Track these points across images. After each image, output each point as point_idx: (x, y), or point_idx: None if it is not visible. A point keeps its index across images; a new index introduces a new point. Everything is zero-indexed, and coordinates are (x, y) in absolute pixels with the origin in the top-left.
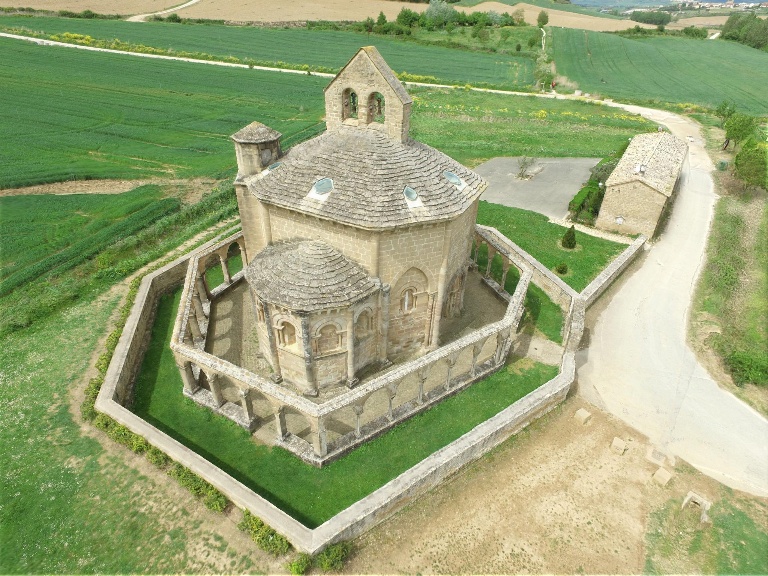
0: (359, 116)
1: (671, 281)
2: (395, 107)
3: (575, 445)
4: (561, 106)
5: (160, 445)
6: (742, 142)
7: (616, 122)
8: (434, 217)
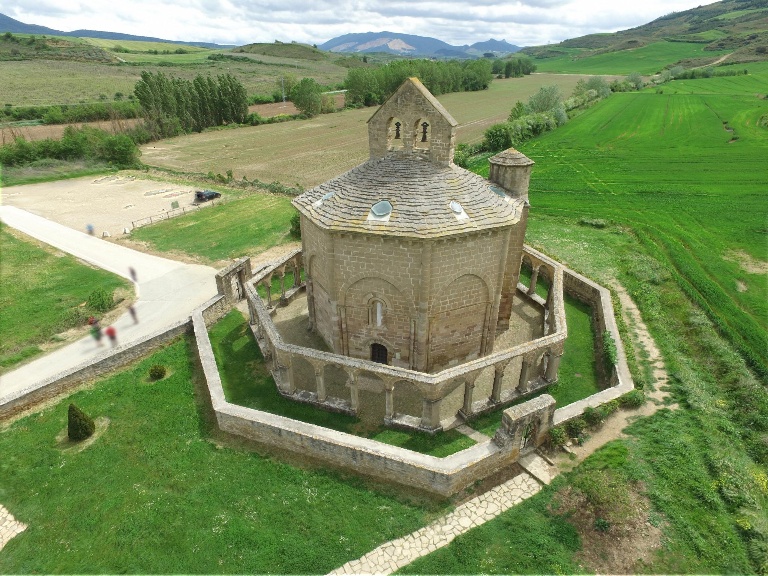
0: None
1: (3, 389)
2: None
3: None
4: None
5: None
6: None
7: None
8: None
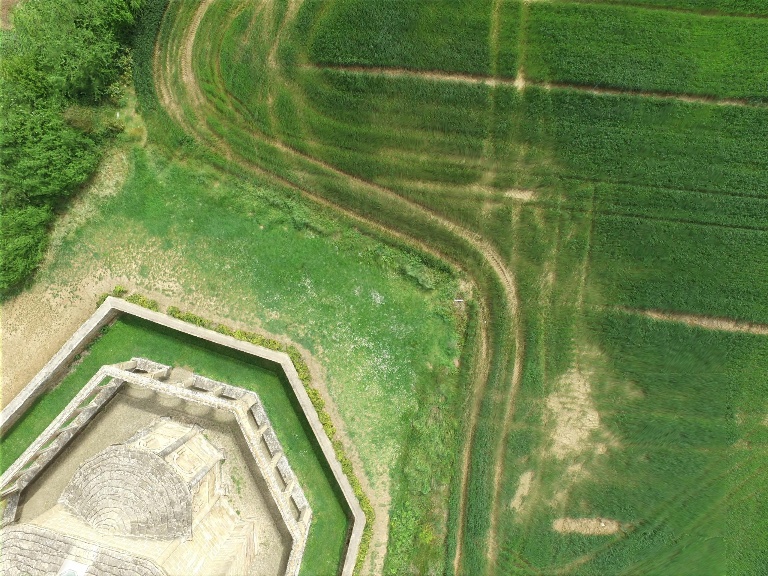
0: None
1: None
2: None
3: None
4: None
5: (224, 337)
6: None
7: None
8: None
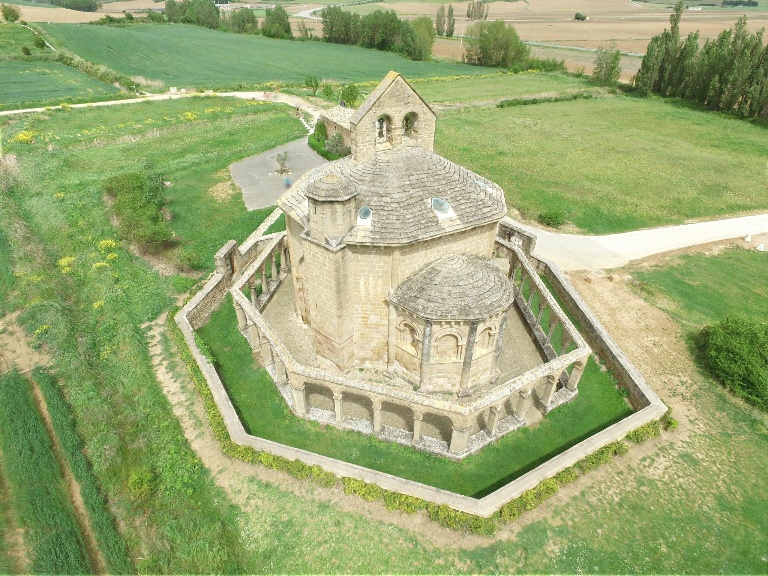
0: (394, 138)
1: None
2: (429, 121)
3: (584, 292)
4: (187, 105)
5: (556, 469)
6: (355, 102)
7: (253, 108)
8: (502, 194)
